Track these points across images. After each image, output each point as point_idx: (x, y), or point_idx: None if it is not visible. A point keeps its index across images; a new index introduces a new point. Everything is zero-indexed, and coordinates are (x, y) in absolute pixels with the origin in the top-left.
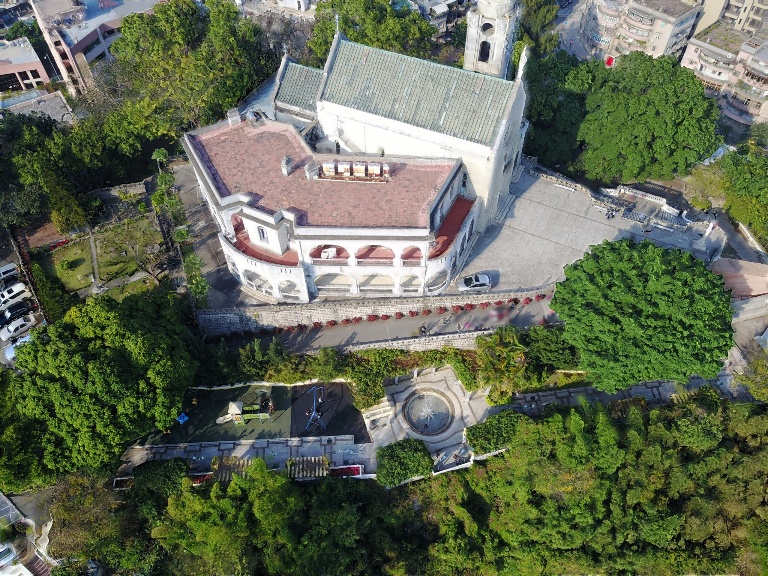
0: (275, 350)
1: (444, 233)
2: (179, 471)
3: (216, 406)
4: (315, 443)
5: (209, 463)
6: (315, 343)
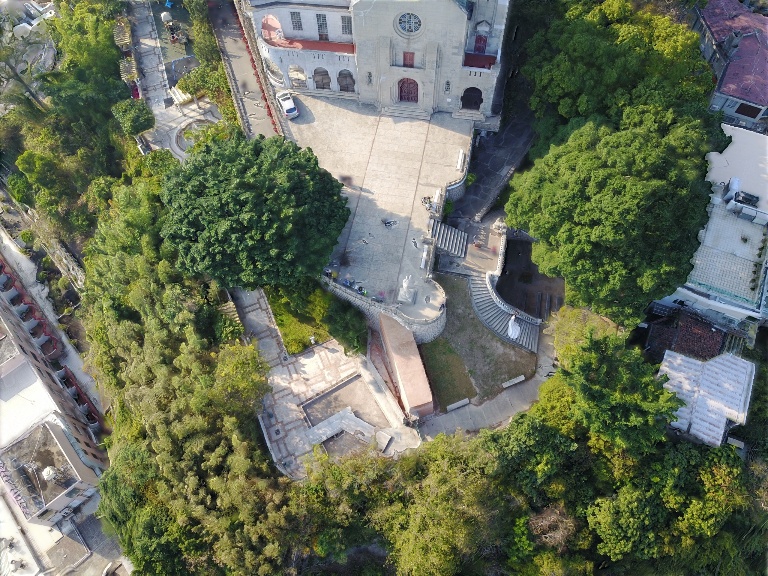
0: (196, 6)
1: (306, 46)
2: (113, 5)
3: (183, 18)
4: (162, 78)
5: (140, 30)
6: (228, 39)
